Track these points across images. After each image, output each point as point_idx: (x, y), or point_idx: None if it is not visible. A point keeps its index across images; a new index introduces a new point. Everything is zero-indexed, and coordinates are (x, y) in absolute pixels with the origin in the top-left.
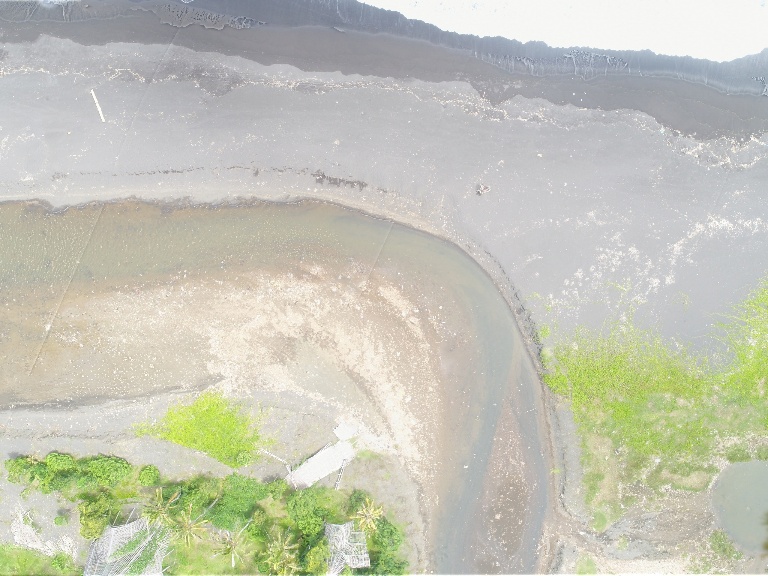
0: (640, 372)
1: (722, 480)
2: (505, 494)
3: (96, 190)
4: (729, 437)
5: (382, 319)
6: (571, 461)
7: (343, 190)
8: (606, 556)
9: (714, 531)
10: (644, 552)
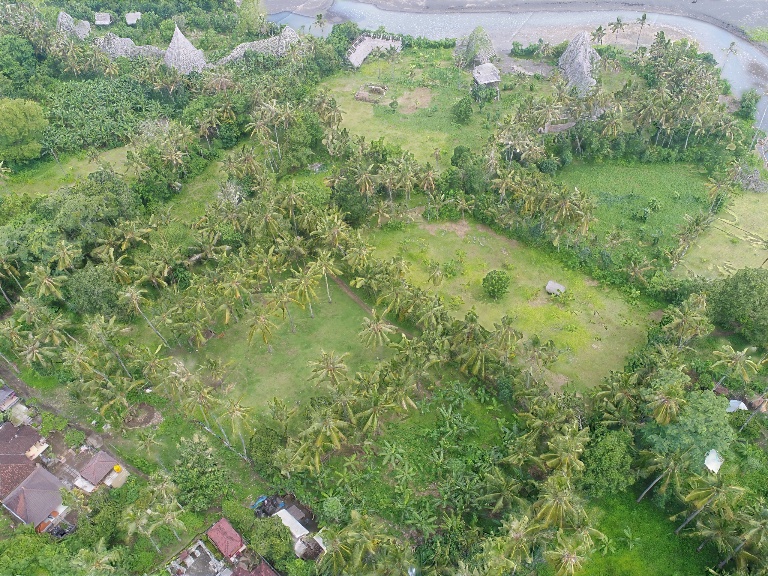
0: None
1: None
2: None
3: None
4: None
5: None
6: None
7: (635, 7)
8: None
9: None
10: None
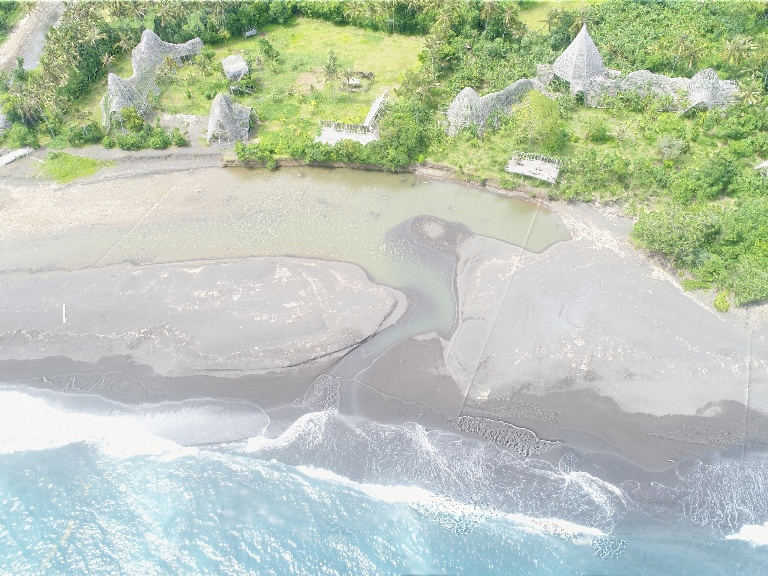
0: None
1: None
2: None
3: (94, 272)
4: None
5: None
6: None
7: None
8: None
9: None
10: None
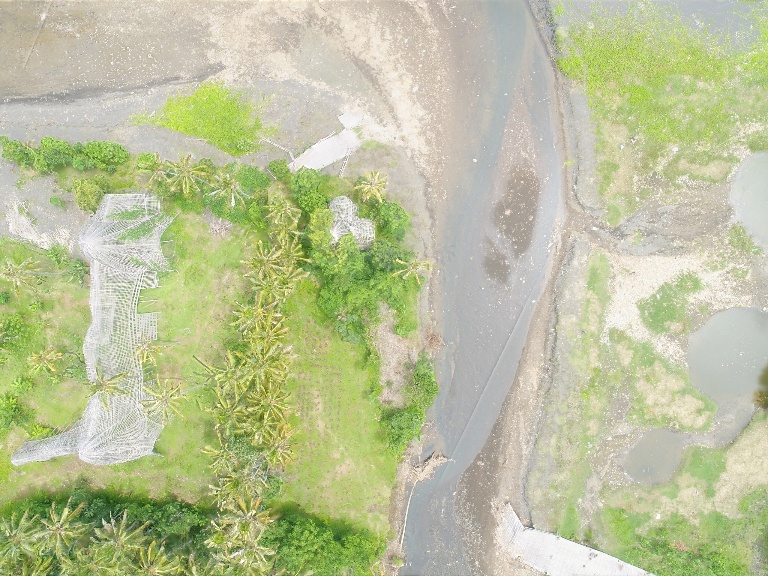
0: (658, 52)
1: (742, 171)
2: (515, 188)
3: None
4: (750, 123)
5: (389, 4)
6: (585, 149)
7: None
8: (620, 252)
9: (733, 225)
10: (659, 247)
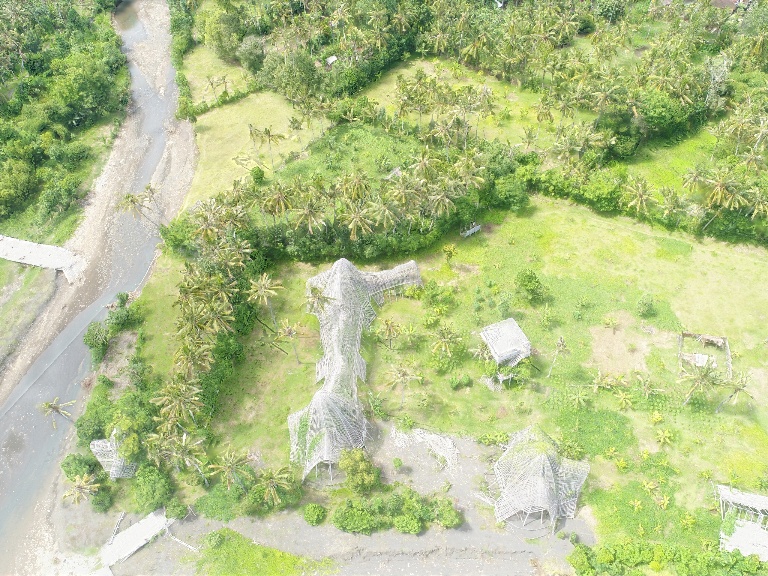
0: None
1: None
2: None
3: None
4: None
5: None
6: None
7: None
8: None
9: None
10: None
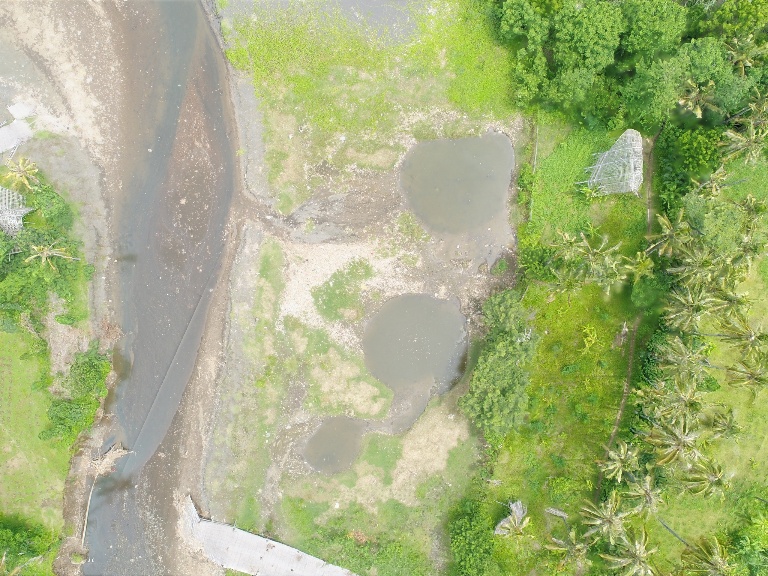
0: (321, 44)
1: (410, 160)
2: (190, 178)
3: None
4: (414, 113)
5: None
6: (253, 138)
7: None
8: (293, 240)
9: (402, 212)
10: (332, 235)
